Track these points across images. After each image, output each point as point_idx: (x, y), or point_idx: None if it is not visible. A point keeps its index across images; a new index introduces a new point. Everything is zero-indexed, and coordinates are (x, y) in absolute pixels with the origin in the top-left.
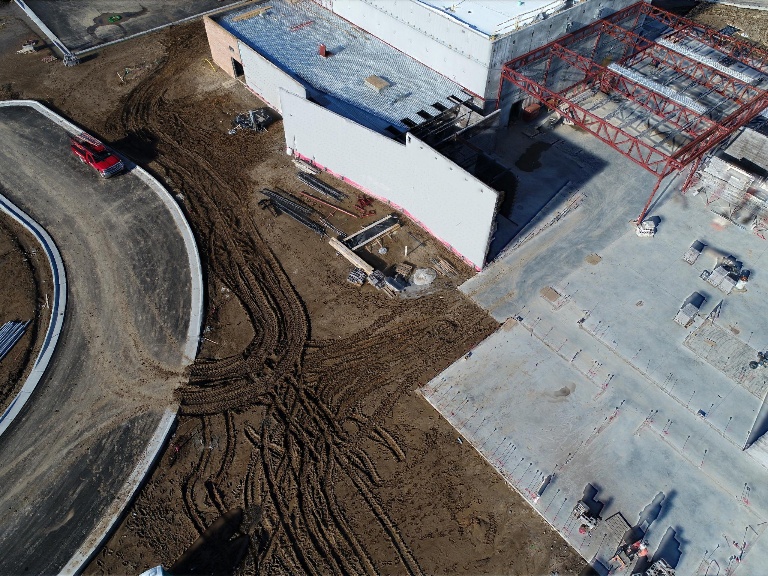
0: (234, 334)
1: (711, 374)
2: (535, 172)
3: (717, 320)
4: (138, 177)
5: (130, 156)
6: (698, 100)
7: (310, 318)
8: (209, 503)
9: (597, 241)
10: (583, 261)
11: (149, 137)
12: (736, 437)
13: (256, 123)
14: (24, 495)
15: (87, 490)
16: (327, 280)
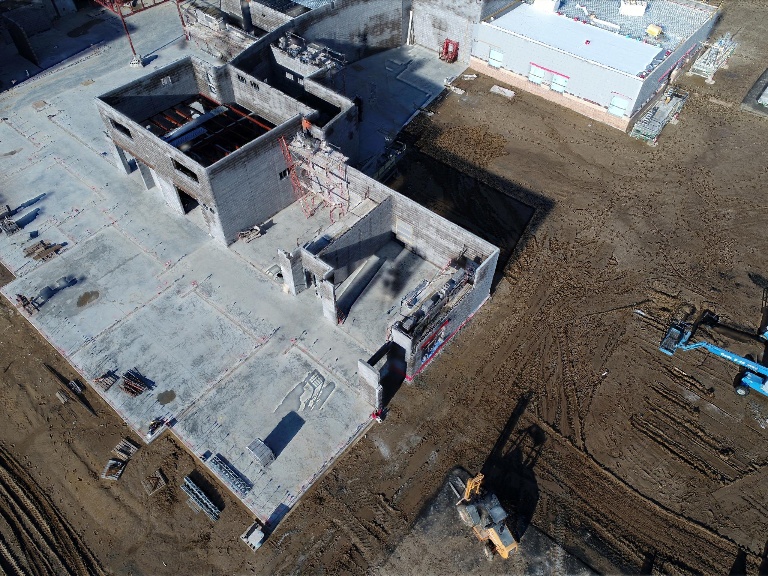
0: None
1: None
2: (79, 37)
3: None
4: None
5: None
6: None
7: None
8: None
9: (98, 73)
10: (79, 84)
11: None
12: None
13: None
14: None
15: None
16: None
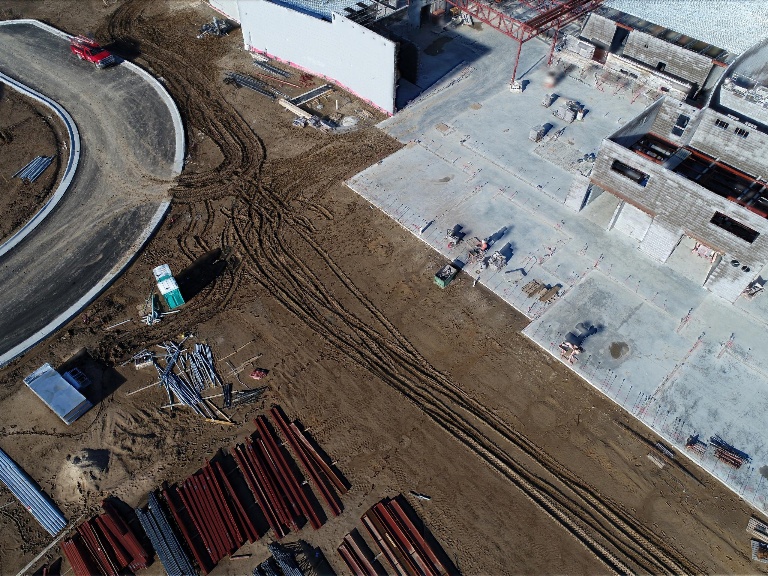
0: (209, 159)
1: (550, 167)
2: (438, 56)
3: (560, 138)
4: (127, 68)
5: (118, 54)
6: None
7: (265, 148)
8: (197, 247)
9: (480, 96)
10: (468, 108)
11: (133, 42)
12: (560, 198)
13: (219, 29)
14: (66, 248)
15: (111, 244)
16: (278, 125)
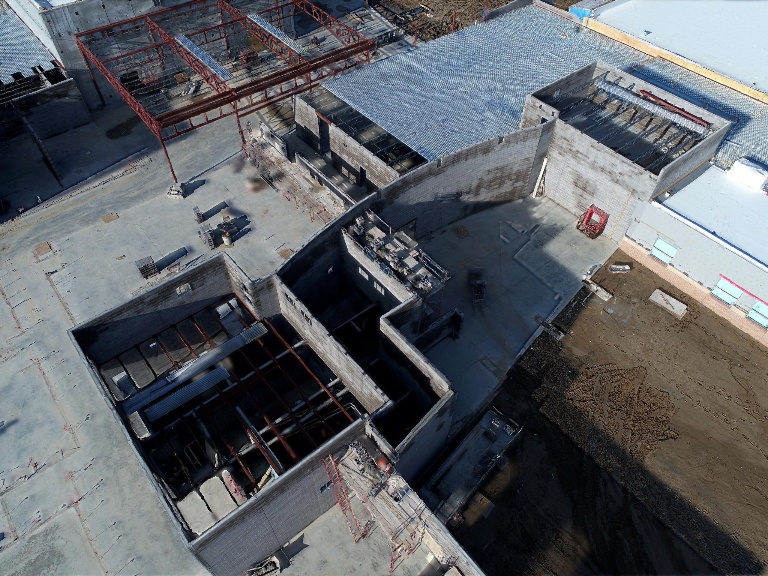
0: None
1: None
2: (119, 140)
3: None
4: None
5: None
6: (240, 69)
7: None
8: None
9: (127, 202)
10: (98, 220)
11: None
12: None
13: None
14: None
15: None
16: None
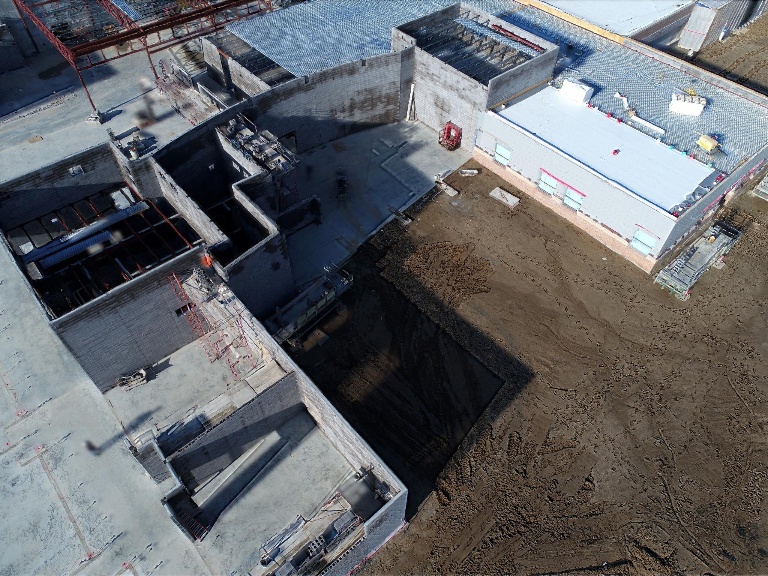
0: None
1: None
2: (49, 80)
3: None
4: None
5: None
6: (151, 12)
7: None
8: None
9: (51, 127)
10: (24, 141)
11: None
12: None
13: None
14: None
15: None
16: None
